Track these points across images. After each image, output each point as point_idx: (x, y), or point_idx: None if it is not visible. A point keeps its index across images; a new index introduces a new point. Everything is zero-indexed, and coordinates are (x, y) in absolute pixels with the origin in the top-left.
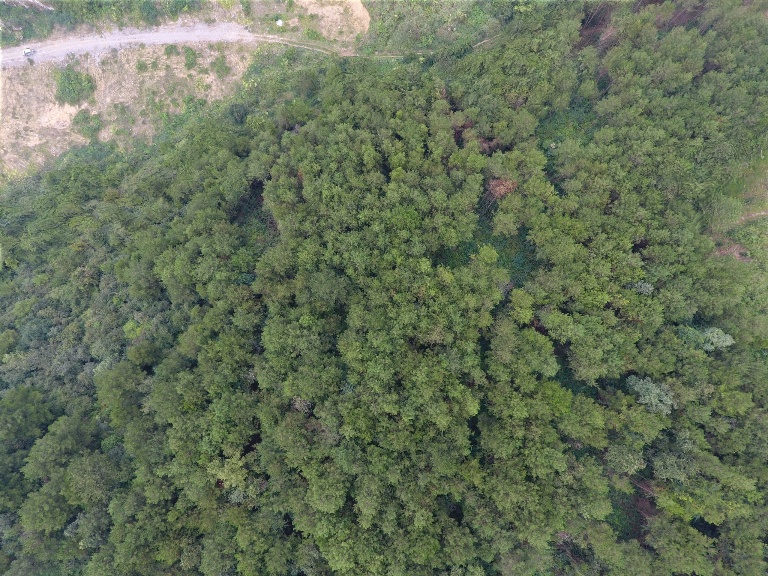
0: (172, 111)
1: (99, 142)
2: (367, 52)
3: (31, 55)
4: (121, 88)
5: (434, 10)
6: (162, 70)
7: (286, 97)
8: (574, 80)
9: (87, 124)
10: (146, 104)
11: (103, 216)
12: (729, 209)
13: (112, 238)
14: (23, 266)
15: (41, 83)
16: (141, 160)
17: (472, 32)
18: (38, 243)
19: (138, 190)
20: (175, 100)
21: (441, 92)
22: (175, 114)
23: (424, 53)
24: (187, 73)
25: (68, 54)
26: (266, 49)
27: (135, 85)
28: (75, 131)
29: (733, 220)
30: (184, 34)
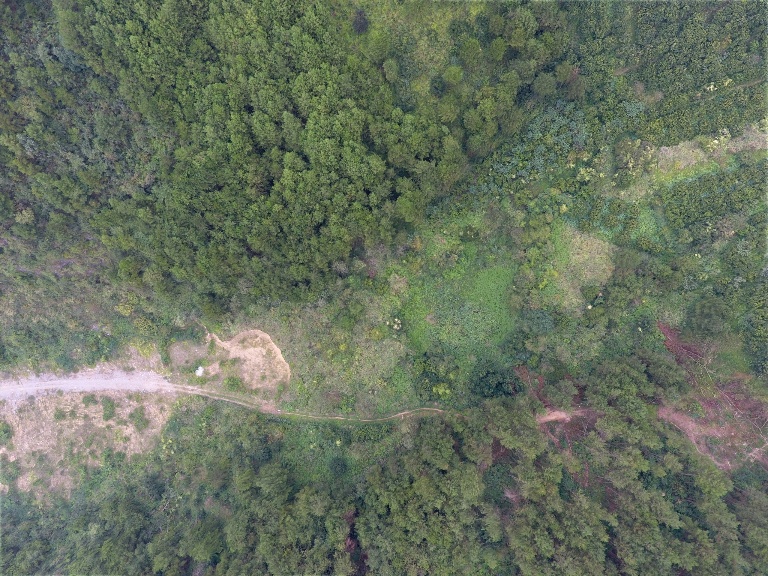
0: (91, 463)
1: (17, 491)
2: (288, 409)
3: None
4: (39, 436)
5: (354, 372)
6: (80, 419)
7: (201, 477)
8: (475, 559)
9: (5, 470)
10: (64, 455)
11: None
12: None
13: None
14: None
15: None
16: (56, 530)
17: (392, 401)
18: None
19: None
20: (93, 452)
21: (345, 541)
22: (93, 469)
23: (344, 418)
24: (106, 423)
25: None
26: (185, 403)
27: (53, 433)
28: None
29: None
30: (102, 381)
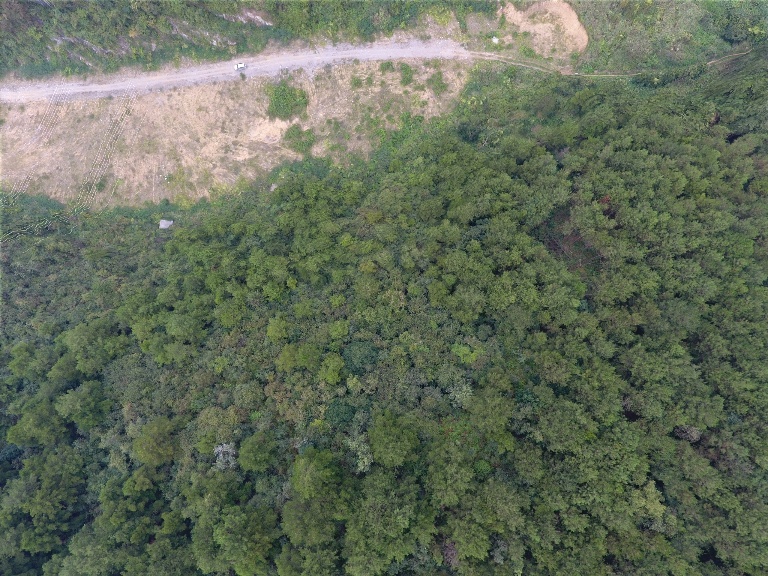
0: (388, 127)
1: (312, 157)
2: (587, 71)
3: (243, 70)
4: (335, 104)
5: (657, 30)
6: (377, 86)
7: (519, 116)
8: None
9: (299, 139)
10: (361, 120)
11: (382, 237)
12: None
13: (409, 260)
14: (305, 286)
15: (252, 98)
16: (367, 177)
17: (698, 53)
18: (319, 263)
19: (403, 210)
20: (391, 116)
21: None
22: (393, 130)
23: None
24: (402, 89)
25: (282, 69)
26: (484, 66)
27: (349, 101)
28: (286, 146)
29: None
30: (398, 50)
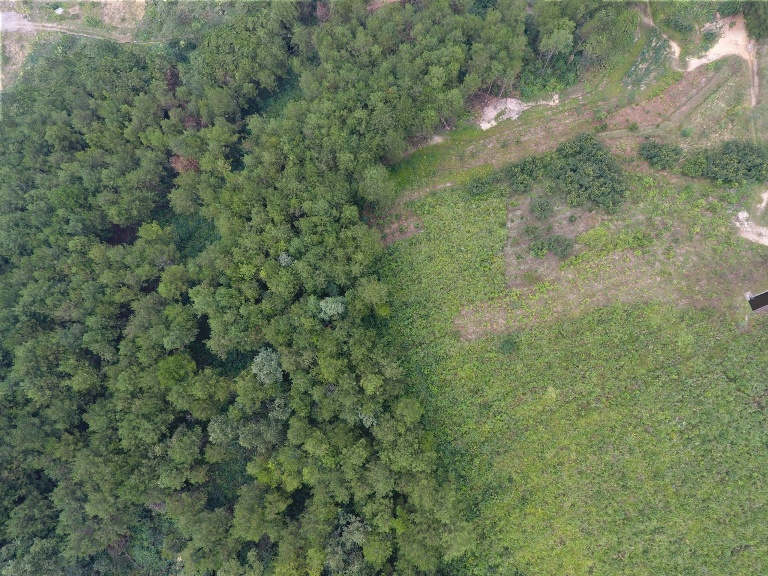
0: None
1: None
2: (143, 38)
3: None
4: None
5: None
6: None
7: (50, 84)
8: (279, 57)
9: None
10: None
11: None
12: (407, 181)
13: None
14: None
15: None
16: None
17: (240, 15)
18: None
19: None
20: None
21: (165, 73)
22: None
23: None
24: None
25: None
26: (44, 38)
27: None
28: None
29: (414, 192)
30: None
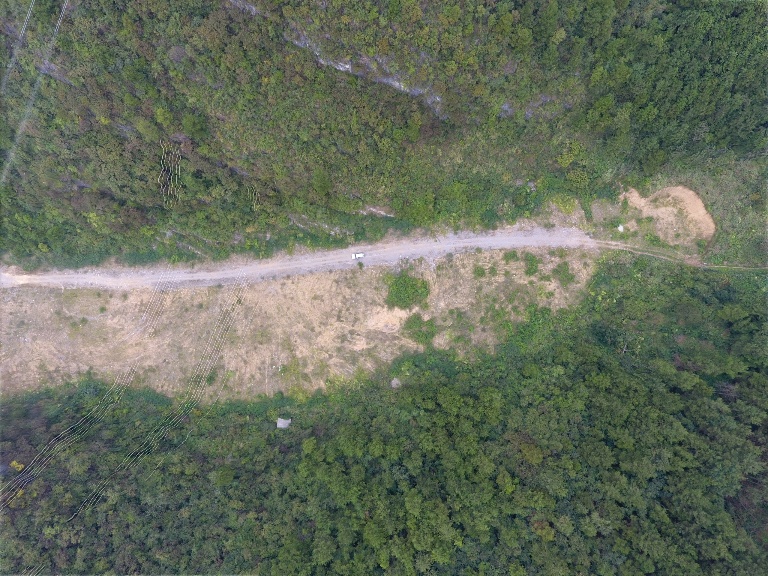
0: (514, 319)
1: (435, 349)
2: (716, 262)
3: (360, 258)
4: (457, 293)
5: None
6: (500, 276)
7: (658, 320)
8: None
9: (419, 329)
10: (486, 311)
11: (552, 489)
12: None
13: (592, 529)
14: (473, 545)
15: (370, 286)
16: (499, 379)
17: None
18: (489, 521)
19: (563, 448)
20: (516, 308)
21: None
22: (520, 324)
23: None
24: (527, 279)
25: (402, 259)
26: (612, 257)
27: (472, 290)
28: (405, 335)
29: None
30: (522, 238)
